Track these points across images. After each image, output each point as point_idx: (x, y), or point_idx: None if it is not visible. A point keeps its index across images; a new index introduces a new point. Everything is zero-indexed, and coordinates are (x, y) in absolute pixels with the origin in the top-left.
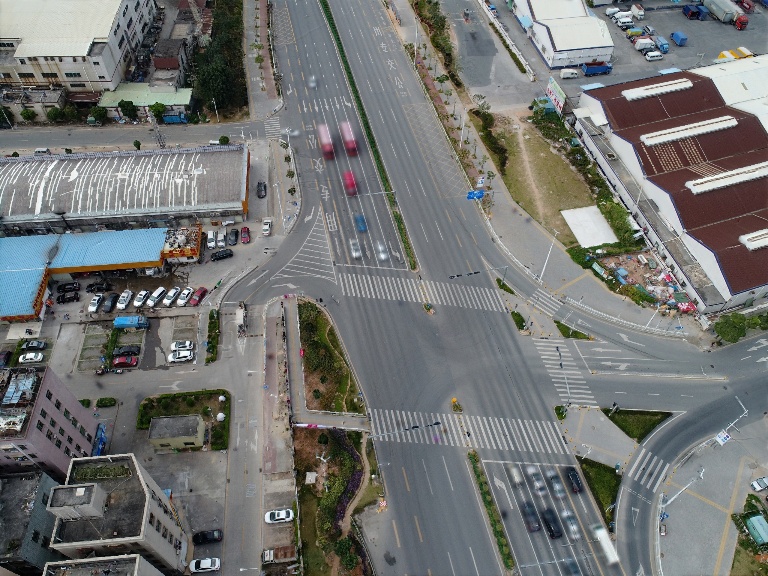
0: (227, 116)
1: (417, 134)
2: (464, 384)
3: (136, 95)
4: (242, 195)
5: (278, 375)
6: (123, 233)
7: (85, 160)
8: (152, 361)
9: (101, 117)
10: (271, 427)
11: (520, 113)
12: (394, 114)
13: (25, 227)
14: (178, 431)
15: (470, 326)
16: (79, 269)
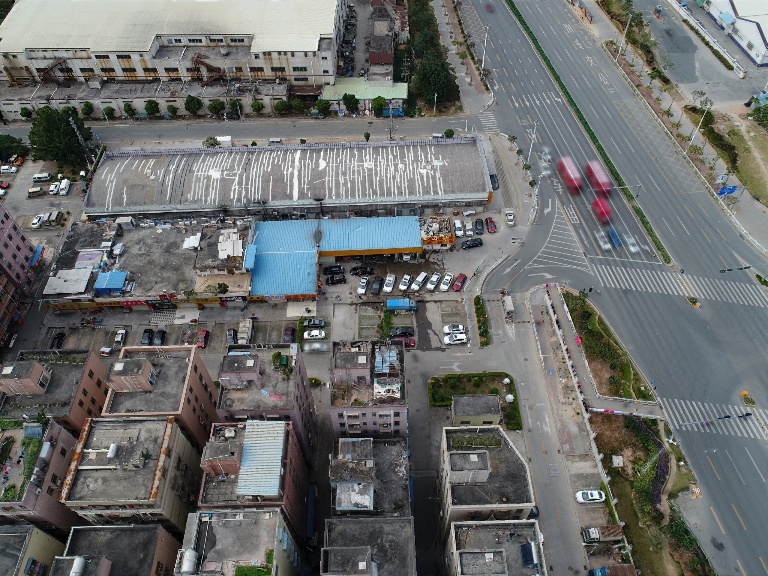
0: (442, 110)
1: (635, 130)
2: (749, 378)
3: (355, 89)
4: (489, 186)
5: (555, 361)
6: (377, 220)
7: (326, 150)
8: (428, 342)
9: (325, 110)
10: (560, 411)
11: (737, 110)
12: (607, 110)
13: (282, 212)
14: (481, 409)
15: (740, 321)
16: (346, 253)
